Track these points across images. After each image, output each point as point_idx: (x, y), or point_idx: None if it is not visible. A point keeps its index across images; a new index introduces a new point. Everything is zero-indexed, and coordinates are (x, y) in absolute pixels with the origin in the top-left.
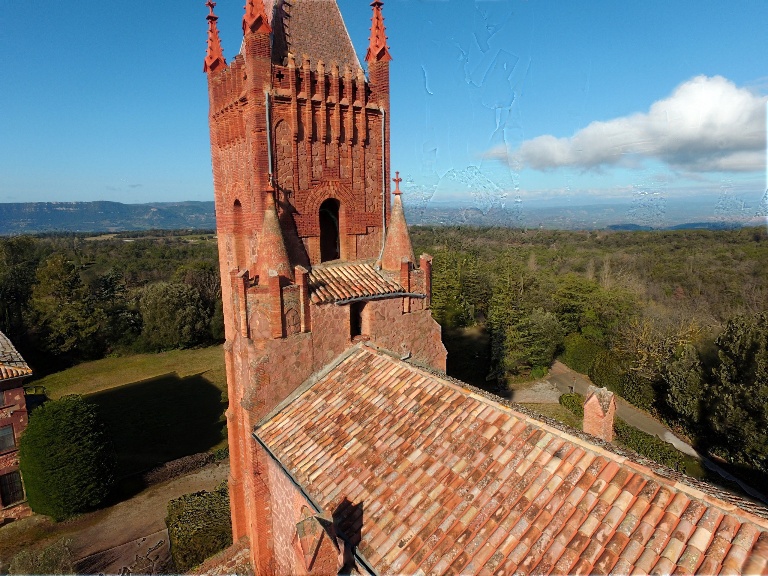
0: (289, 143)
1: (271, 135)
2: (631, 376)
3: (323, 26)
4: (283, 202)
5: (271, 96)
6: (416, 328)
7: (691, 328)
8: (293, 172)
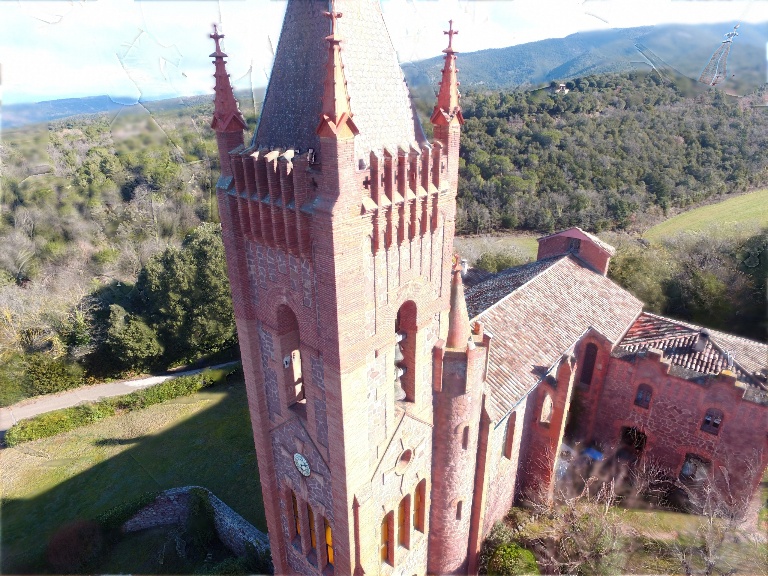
0: None
1: None
2: (37, 370)
3: None
4: None
5: None
6: None
7: (84, 293)
8: None
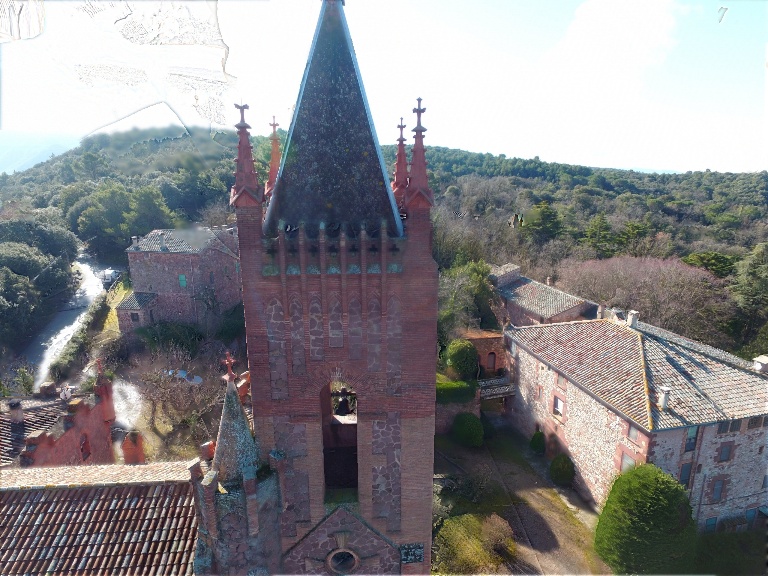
0: None
1: None
2: None
3: None
4: None
5: None
6: None
7: None
8: None
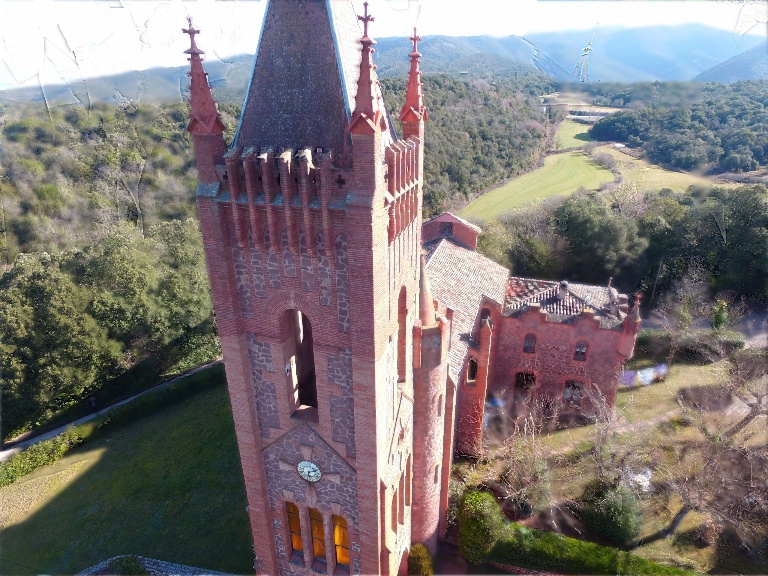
0: None
1: None
2: None
3: None
4: None
5: None
6: None
7: None
8: None
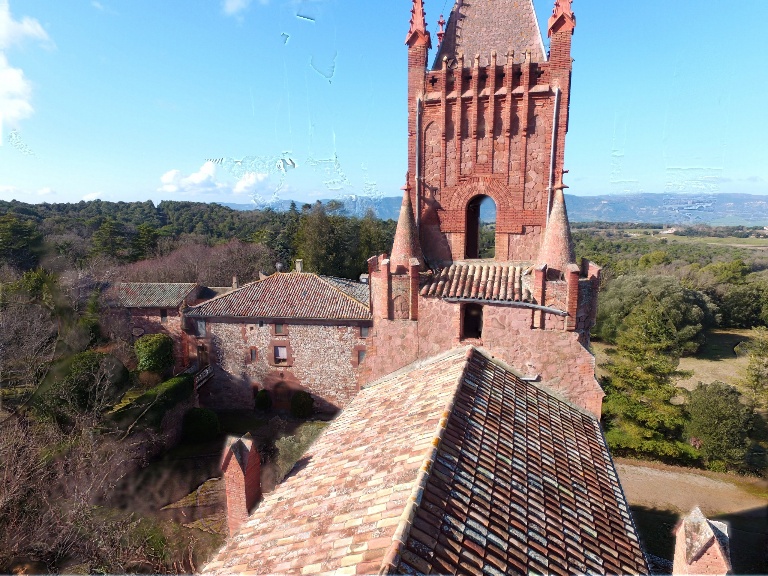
0: (439, 143)
1: (421, 137)
2: None
3: (503, 13)
4: (429, 199)
5: (423, 102)
6: (551, 350)
7: None
8: (441, 170)
